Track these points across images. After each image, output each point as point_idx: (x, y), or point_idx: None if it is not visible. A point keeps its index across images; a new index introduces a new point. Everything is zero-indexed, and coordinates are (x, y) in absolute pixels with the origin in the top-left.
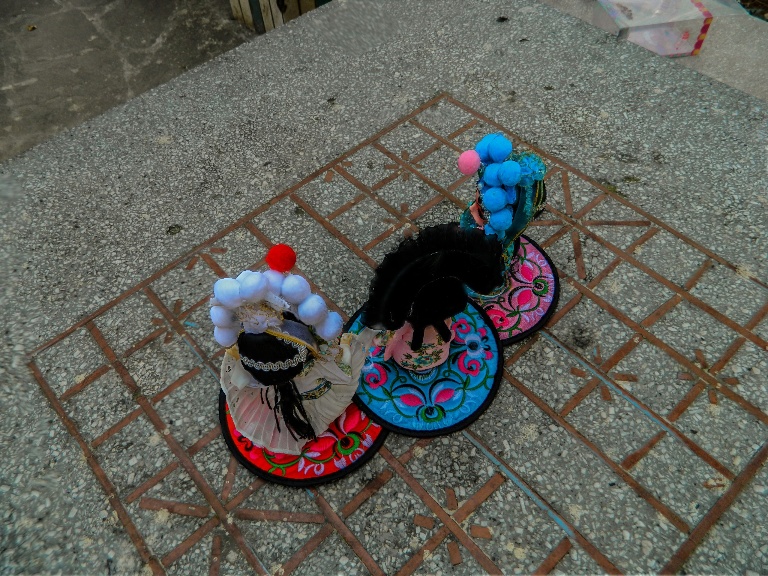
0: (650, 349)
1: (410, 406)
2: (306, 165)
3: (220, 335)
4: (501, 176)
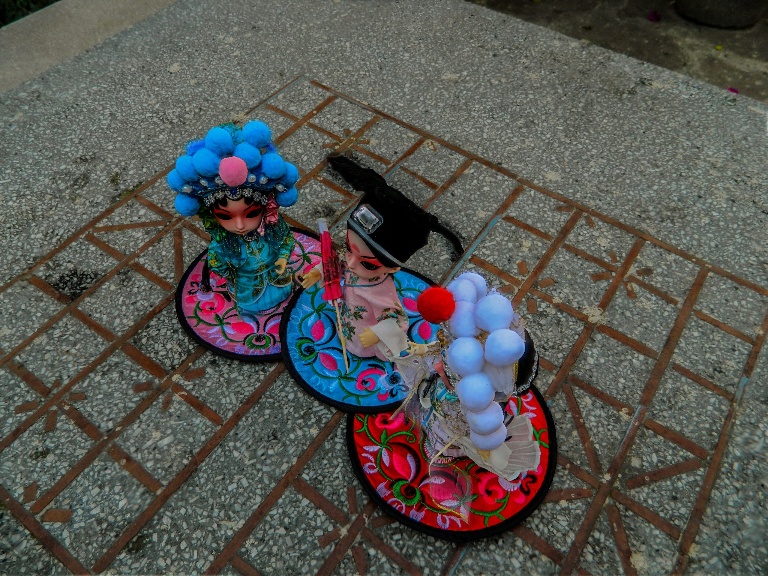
0: (328, 171)
1: (432, 331)
2: (19, 567)
3: (502, 428)
4: (264, 139)
